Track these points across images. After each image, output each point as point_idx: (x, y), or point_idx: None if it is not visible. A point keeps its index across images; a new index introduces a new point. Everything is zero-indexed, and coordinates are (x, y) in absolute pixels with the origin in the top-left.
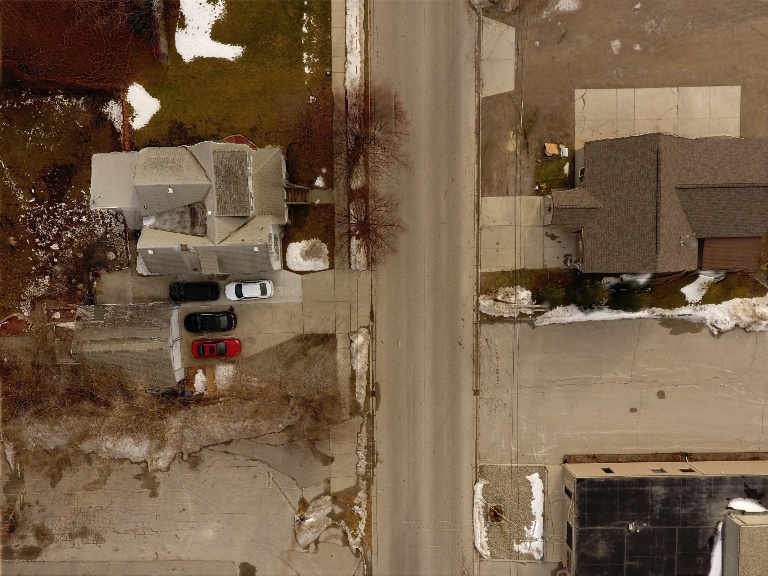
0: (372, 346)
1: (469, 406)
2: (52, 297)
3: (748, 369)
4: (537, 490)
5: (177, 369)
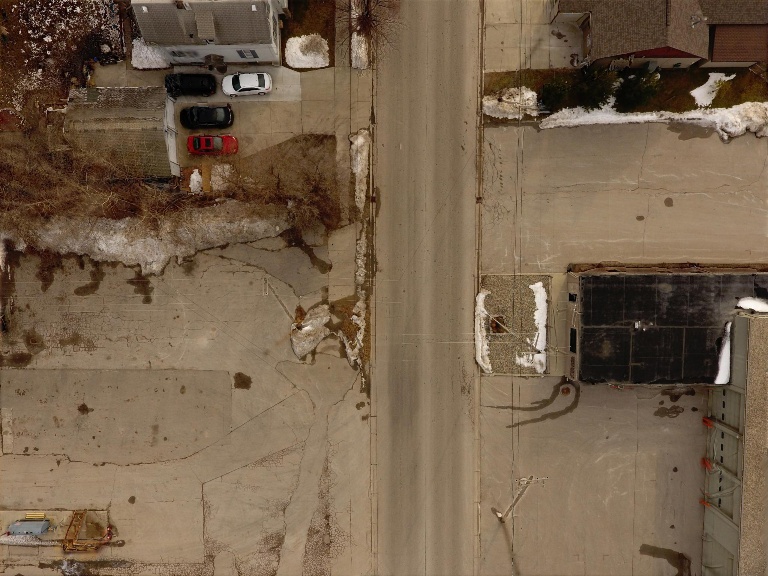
0: (372, 149)
1: (471, 214)
2: (45, 91)
3: (759, 176)
4: (540, 299)
5: (172, 161)
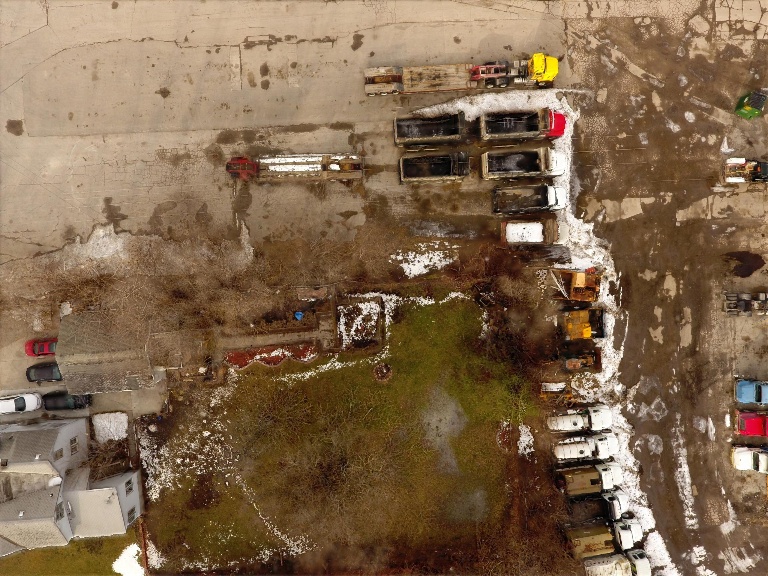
0: None
1: None
2: (207, 387)
3: None
4: None
5: None
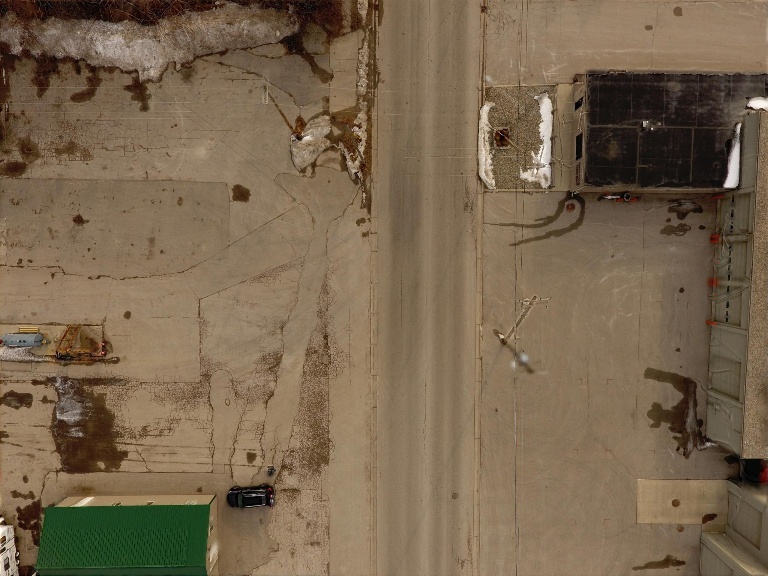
0: None
1: (476, 24)
2: None
3: None
4: (546, 110)
5: None
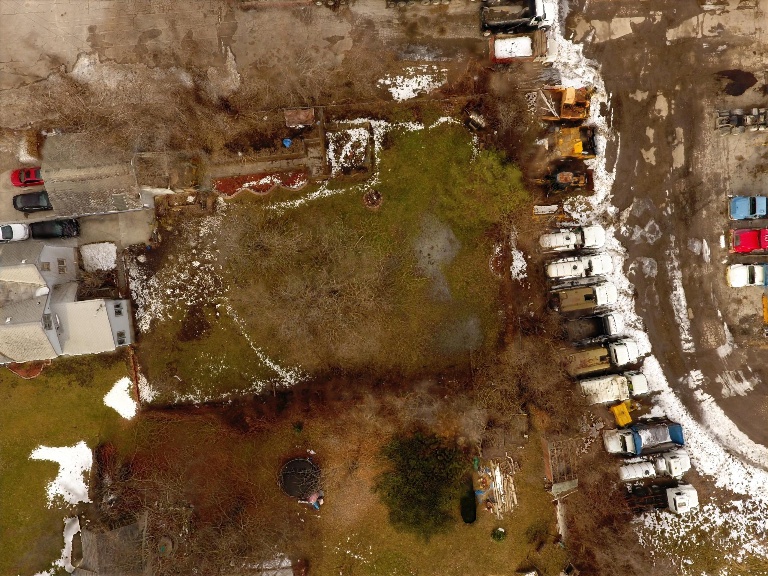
0: None
1: None
2: (196, 216)
3: None
4: None
5: None
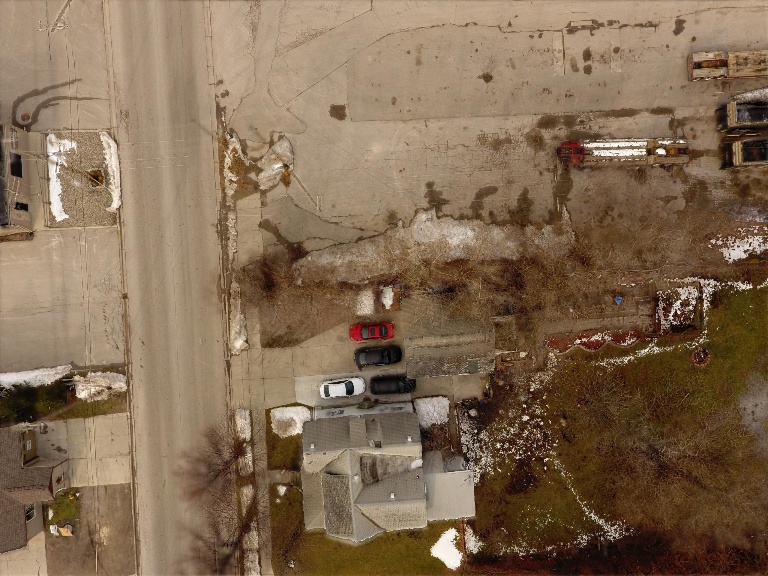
0: (227, 337)
1: (131, 283)
2: (528, 371)
3: None
4: (56, 205)
5: None
